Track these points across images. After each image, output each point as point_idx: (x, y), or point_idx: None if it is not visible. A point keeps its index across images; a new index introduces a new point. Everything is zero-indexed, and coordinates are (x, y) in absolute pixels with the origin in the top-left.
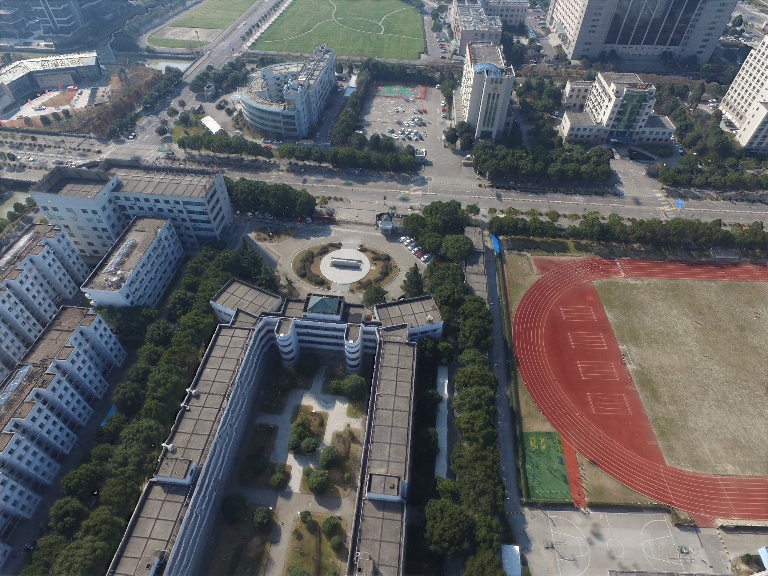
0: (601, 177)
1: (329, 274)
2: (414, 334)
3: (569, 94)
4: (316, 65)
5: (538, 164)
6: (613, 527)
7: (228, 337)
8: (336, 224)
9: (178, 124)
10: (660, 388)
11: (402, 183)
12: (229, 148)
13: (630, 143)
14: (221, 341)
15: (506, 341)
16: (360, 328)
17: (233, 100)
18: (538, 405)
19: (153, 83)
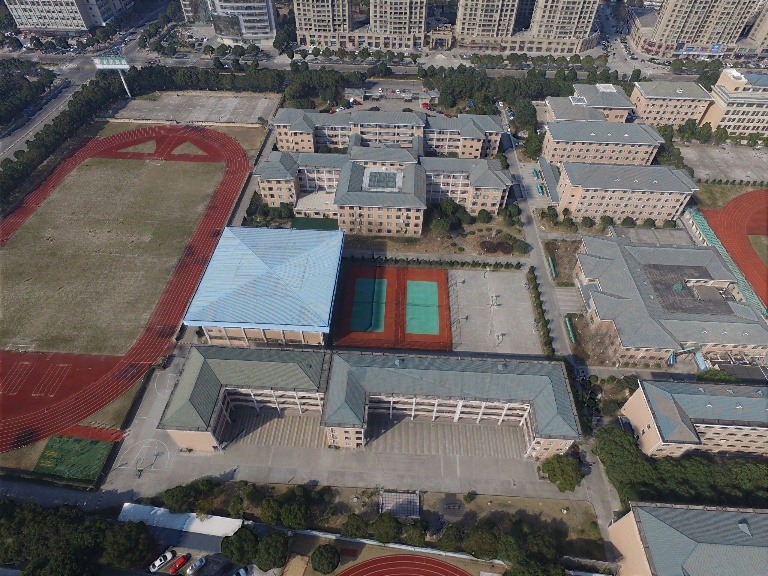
0: None
1: None
2: None
3: None
4: None
5: None
6: (147, 415)
7: None
8: None
9: None
10: (63, 334)
11: None
12: None
13: None
14: None
15: None
16: None
17: None
18: (14, 447)
19: None
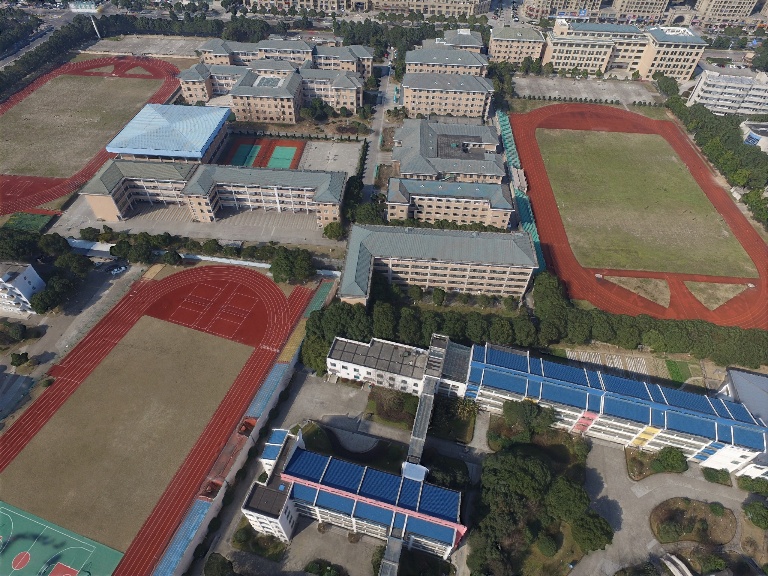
0: None
1: None
2: None
3: None
4: None
5: None
6: (79, 205)
7: None
8: None
9: None
10: (30, 167)
11: None
12: None
13: None
14: None
15: None
16: None
17: None
18: None
19: None
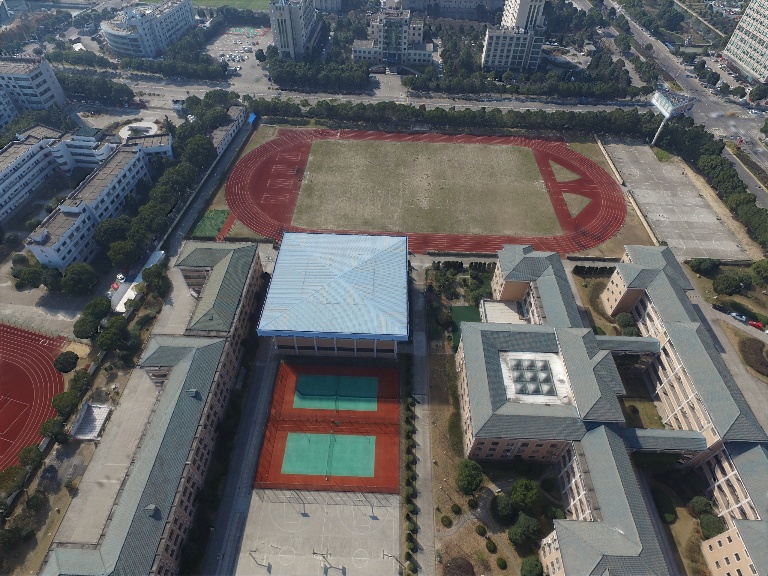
0: (356, 81)
1: (124, 134)
2: (150, 154)
3: (371, 30)
4: (169, 5)
5: (310, 71)
6: None
7: (16, 148)
8: (146, 109)
9: (55, 49)
10: (316, 192)
11: (211, 86)
12: (81, 60)
13: (401, 63)
14: (10, 150)
15: (225, 168)
16: (105, 144)
17: (102, 32)
18: (226, 198)
19: (42, 20)
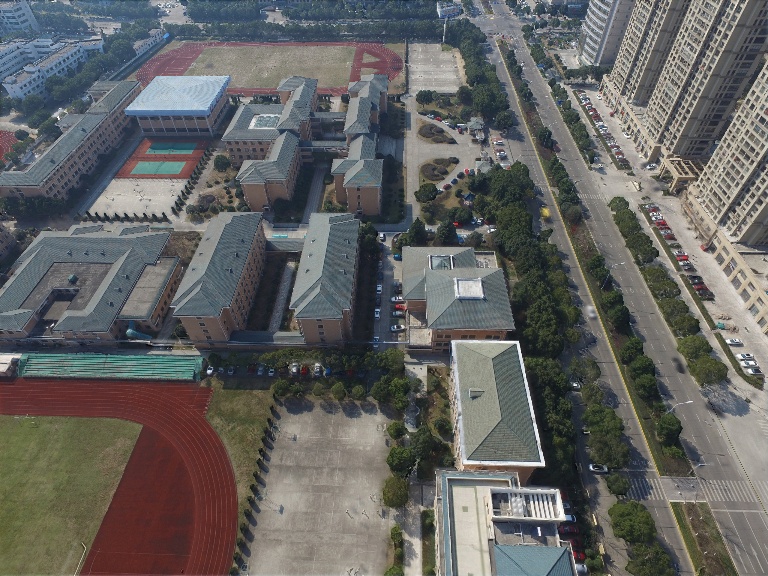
0: (247, 13)
1: None
2: (88, 50)
3: None
4: None
5: (214, 8)
6: None
7: None
8: (96, 35)
9: None
10: None
11: None
12: (53, 8)
13: (288, 4)
14: None
15: None
16: (58, 43)
17: None
18: (137, 76)
19: None
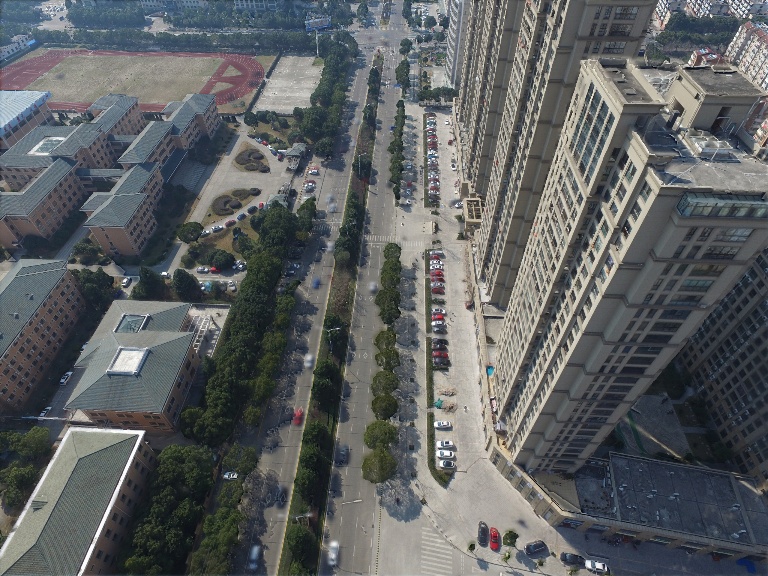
0: (127, 19)
1: None
2: None
3: None
4: None
5: (93, 13)
6: None
7: None
8: None
9: None
10: None
11: None
12: None
13: (179, 10)
14: None
15: None
16: None
17: None
18: None
19: None
